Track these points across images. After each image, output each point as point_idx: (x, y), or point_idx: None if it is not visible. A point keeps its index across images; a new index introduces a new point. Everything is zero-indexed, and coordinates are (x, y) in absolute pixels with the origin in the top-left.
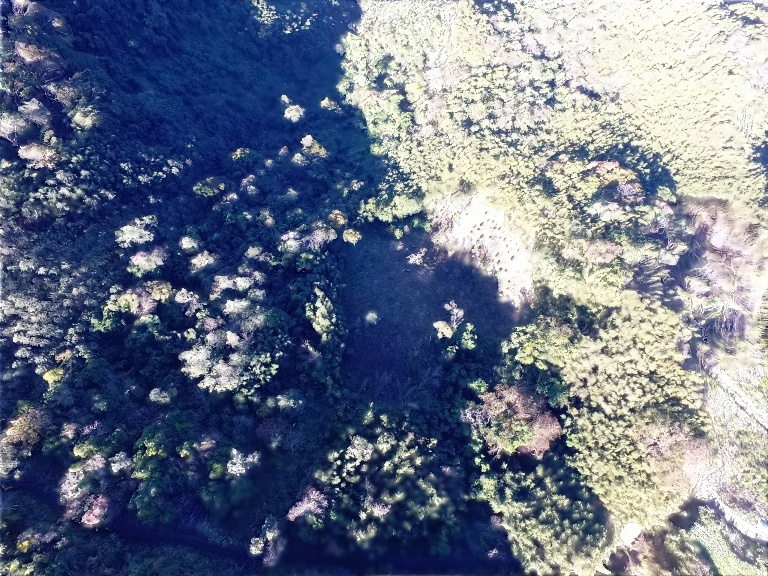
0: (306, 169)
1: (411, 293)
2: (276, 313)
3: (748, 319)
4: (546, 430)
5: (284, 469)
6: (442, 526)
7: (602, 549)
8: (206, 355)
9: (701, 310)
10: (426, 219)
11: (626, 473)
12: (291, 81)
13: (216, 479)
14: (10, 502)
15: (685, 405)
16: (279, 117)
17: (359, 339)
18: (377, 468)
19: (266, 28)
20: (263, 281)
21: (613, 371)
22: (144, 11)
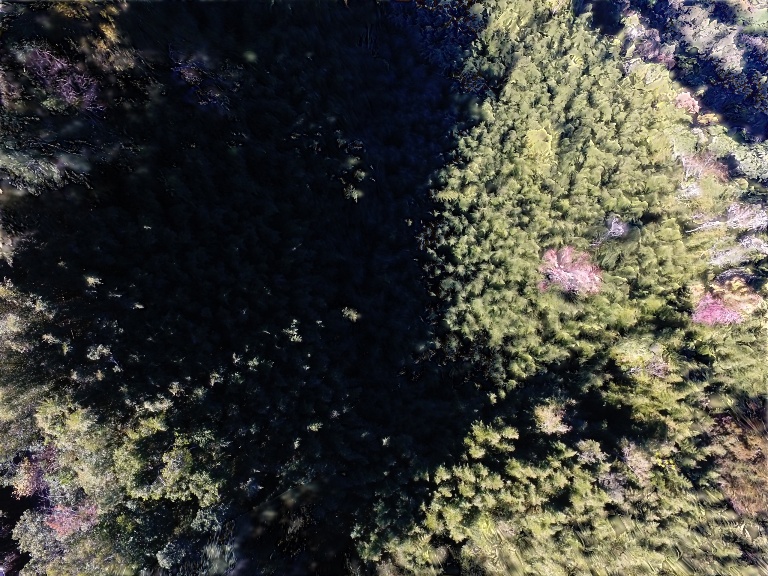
0: None
1: None
2: None
3: None
4: None
5: None
6: None
7: None
8: None
9: None
10: None
11: None
12: None
13: None
14: None
15: None
16: None
17: None
18: None
19: None
20: None
21: None
22: None
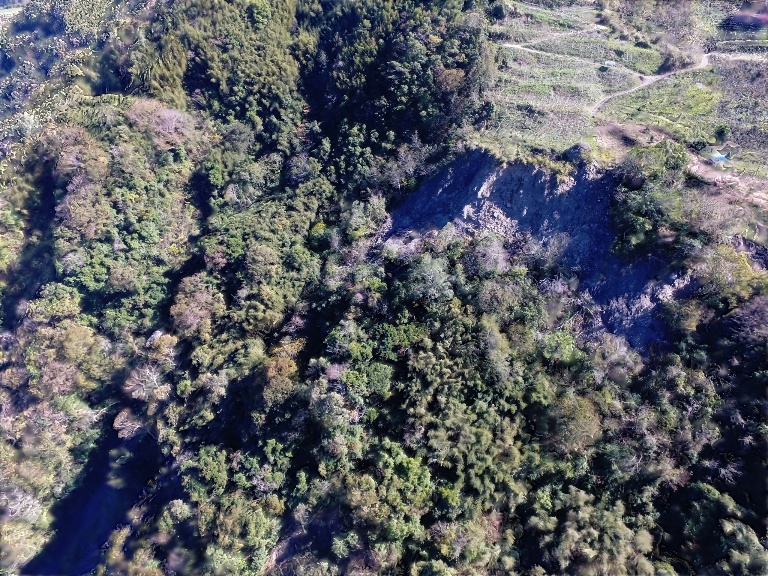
0: None
1: None
2: (10, 82)
3: None
4: None
5: None
6: None
7: None
8: None
9: None
10: None
11: None
12: None
13: None
14: None
15: None
16: None
17: None
18: None
19: None
20: None
21: None
22: None
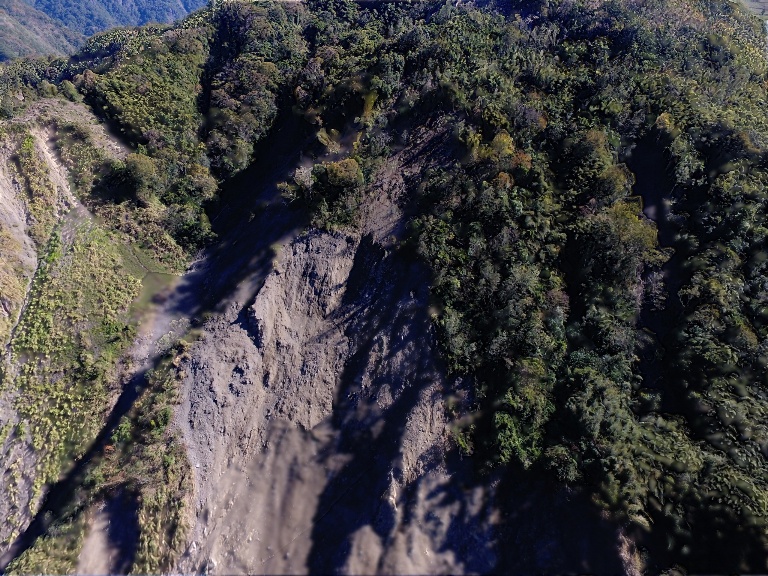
0: None
1: None
2: None
3: None
4: None
5: None
6: None
7: None
8: None
9: None
10: None
11: None
12: None
13: None
14: None
15: None
16: None
17: None
18: None
19: None
20: None
21: None
22: None
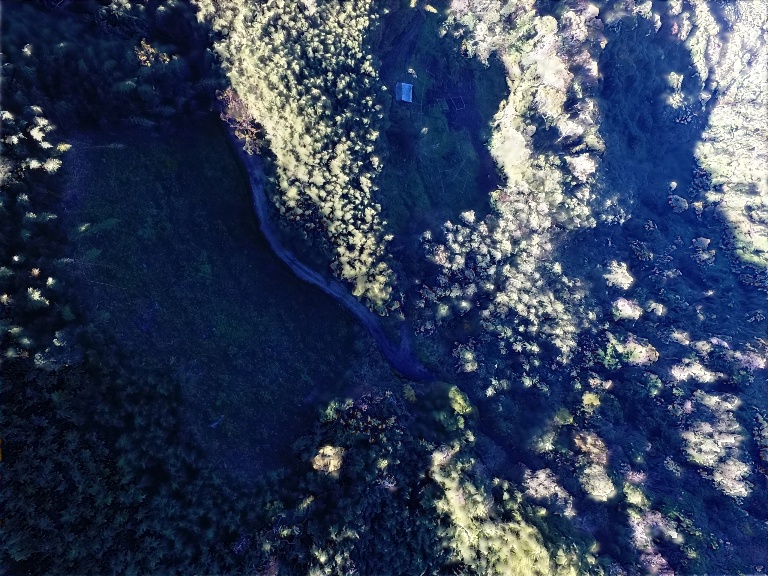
0: (697, 269)
1: None
2: None
3: None
4: None
5: None
6: None
7: None
8: None
9: None
10: None
11: None
12: (652, 162)
13: None
14: None
15: None
16: (656, 198)
17: None
18: None
19: (671, 111)
20: (712, 381)
21: None
22: (616, 53)
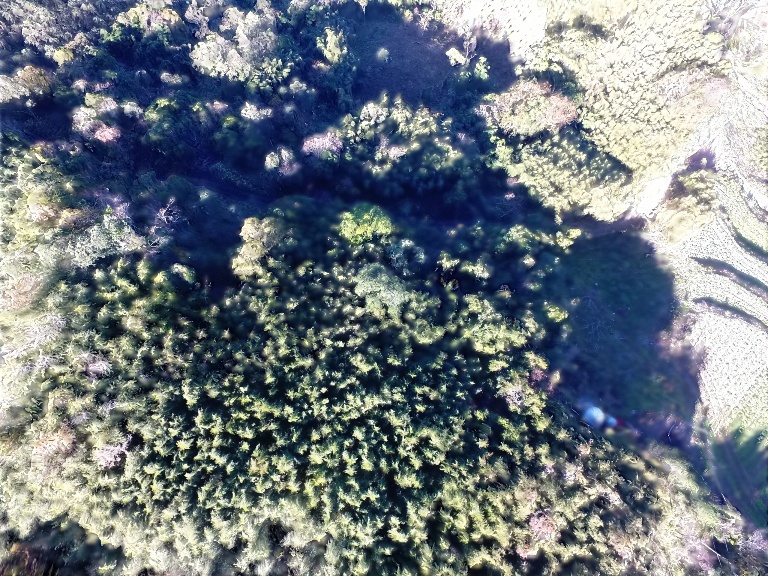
0: None
1: (422, 57)
2: None
3: (765, 46)
4: (563, 101)
5: (297, 151)
6: (458, 180)
7: (621, 187)
8: (217, 47)
9: (719, 8)
10: (436, 10)
11: (645, 124)
12: None
13: (229, 128)
14: (22, 128)
15: (704, 61)
16: None
17: (370, 79)
18: (392, 131)
19: None
20: None
21: (630, 58)
22: None
